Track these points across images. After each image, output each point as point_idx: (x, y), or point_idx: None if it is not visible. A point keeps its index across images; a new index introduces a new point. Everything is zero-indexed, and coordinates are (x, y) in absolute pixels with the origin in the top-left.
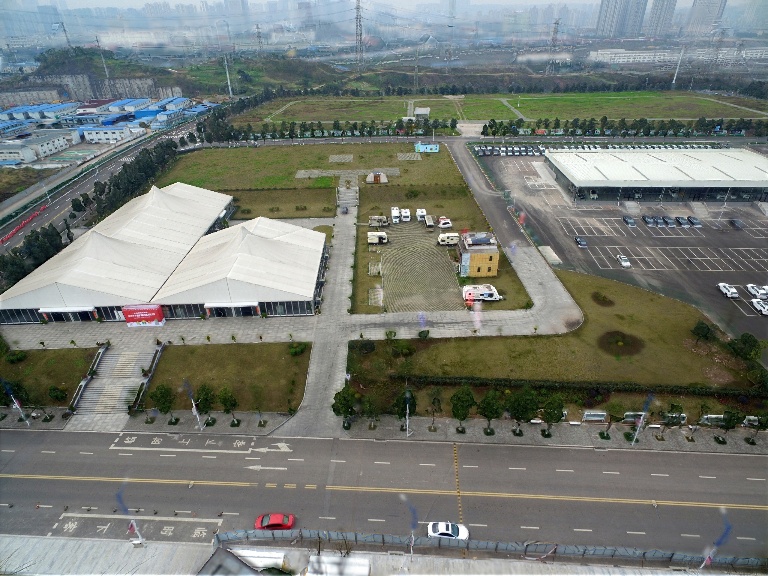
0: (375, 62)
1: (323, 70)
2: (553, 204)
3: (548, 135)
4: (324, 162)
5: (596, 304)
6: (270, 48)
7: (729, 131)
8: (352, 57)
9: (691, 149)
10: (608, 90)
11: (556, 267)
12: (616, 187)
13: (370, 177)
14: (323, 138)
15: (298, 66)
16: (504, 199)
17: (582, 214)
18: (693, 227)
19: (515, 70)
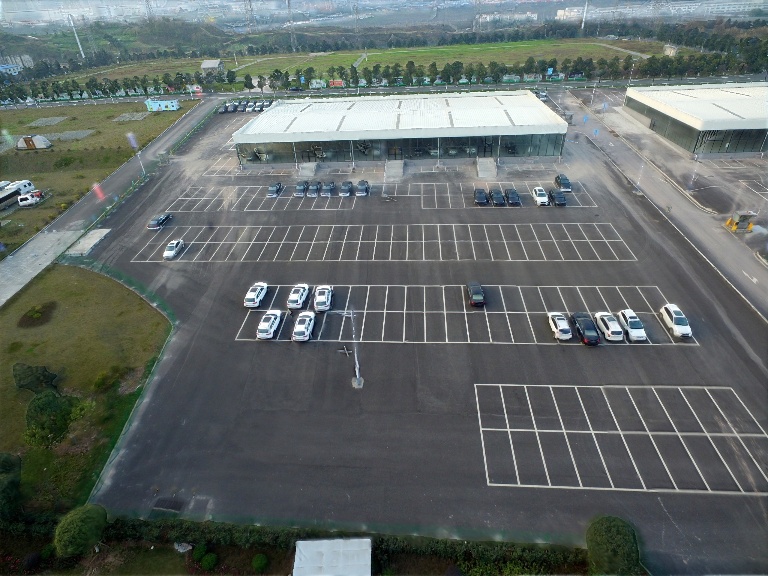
0: (279, 23)
1: (209, 32)
2: (214, 169)
3: (346, 87)
4: (19, 126)
5: (15, 323)
6: (160, 11)
7: (567, 74)
8: (243, 17)
9: (462, 93)
10: (502, 40)
11: (68, 261)
12: (286, 143)
13: (20, 141)
14: (79, 100)
15: (176, 28)
16: (159, 164)
17: (231, 181)
18: (355, 195)
19: (435, 27)
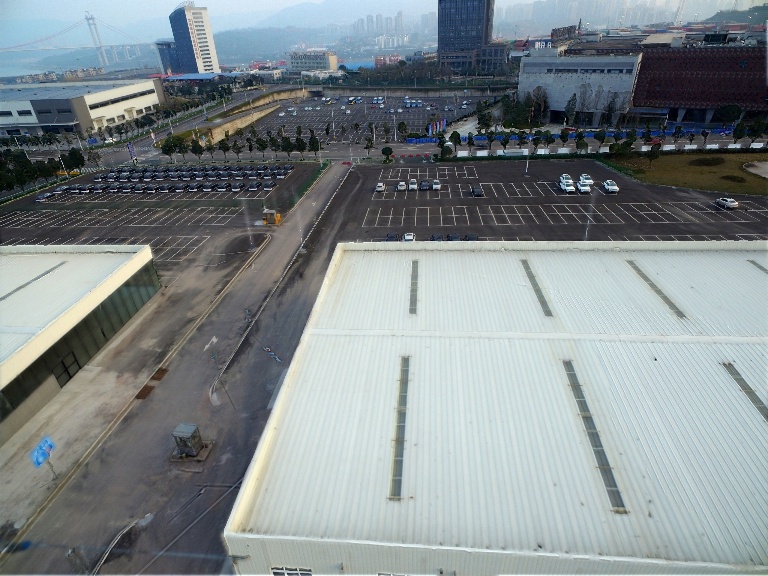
0: None
1: None
2: None
3: None
4: None
5: None
6: None
7: None
8: None
9: None
10: None
11: None
12: None
13: None
14: None
15: None
16: None
17: None
18: None
19: None
